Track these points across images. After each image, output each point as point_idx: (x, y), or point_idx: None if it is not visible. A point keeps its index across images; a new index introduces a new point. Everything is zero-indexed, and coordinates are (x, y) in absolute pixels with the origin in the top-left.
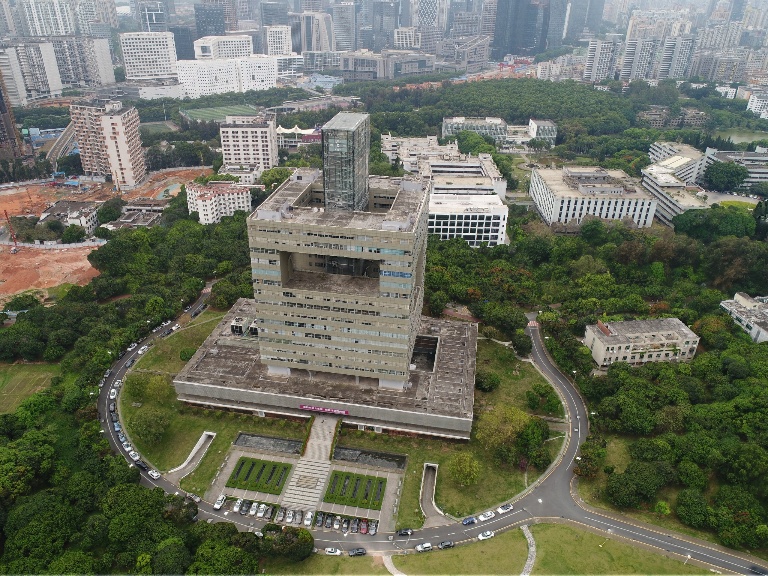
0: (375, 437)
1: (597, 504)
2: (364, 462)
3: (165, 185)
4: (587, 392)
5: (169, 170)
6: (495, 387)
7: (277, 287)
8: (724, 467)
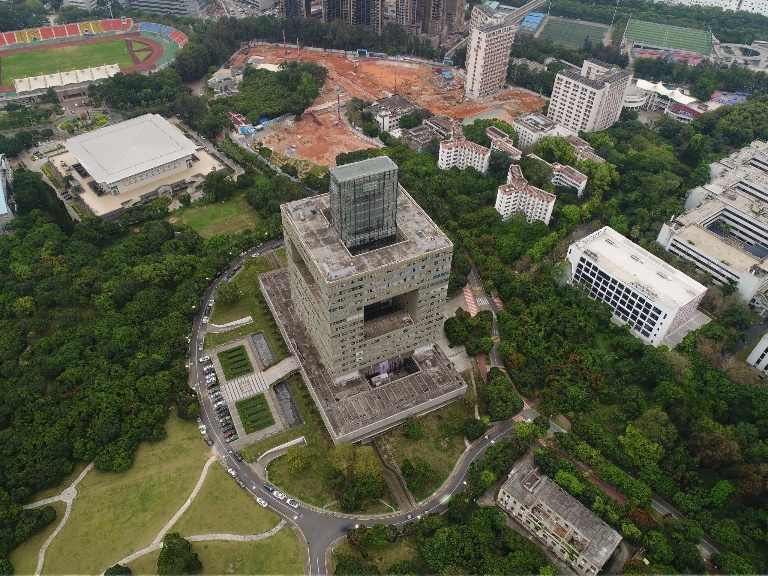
0: (306, 397)
1: (335, 561)
2: (282, 404)
3: (498, 106)
4: (450, 504)
5: (525, 91)
6: (410, 438)
7: (291, 259)
8: None
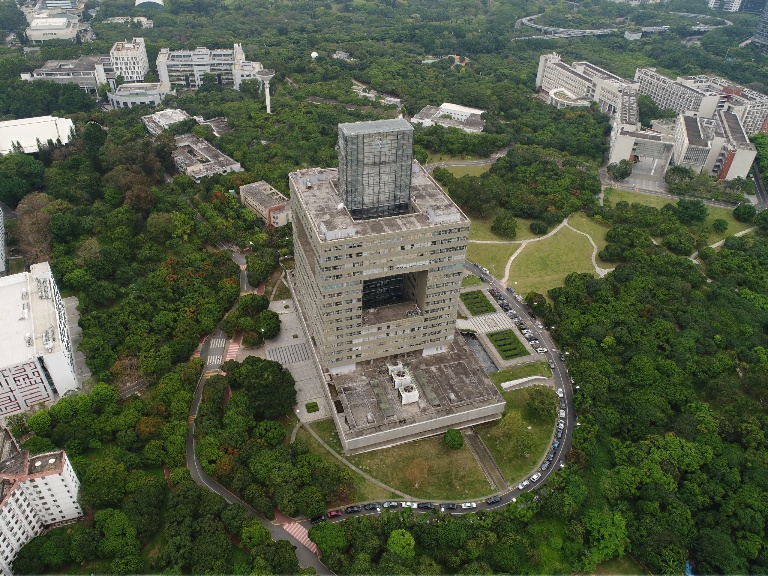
0: None
1: None
2: None
3: None
4: None
5: None
6: None
7: None
8: None
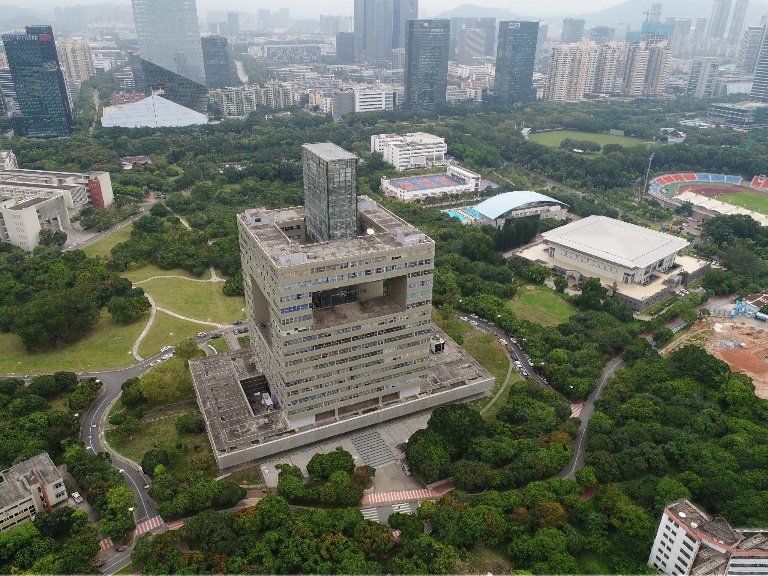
0: None
1: None
2: None
3: None
4: None
5: None
6: None
7: None
8: None
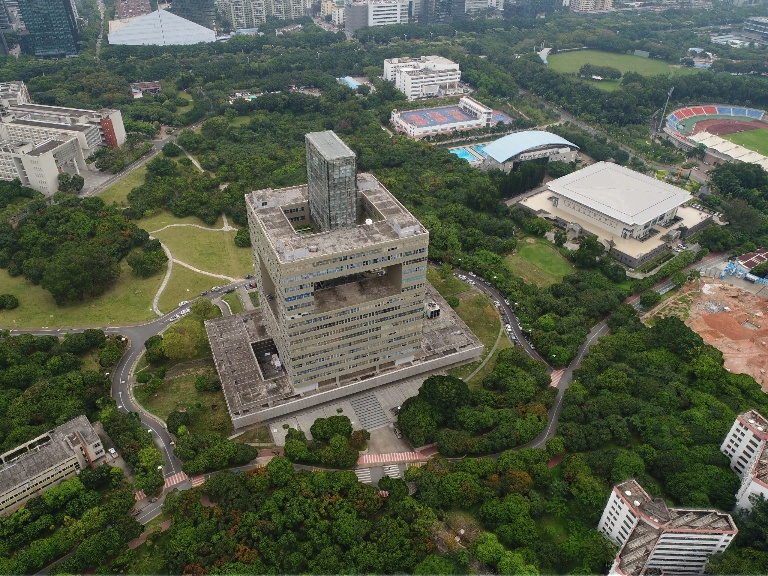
0: None
1: None
2: None
3: None
4: None
5: None
6: None
7: None
8: (8, 365)
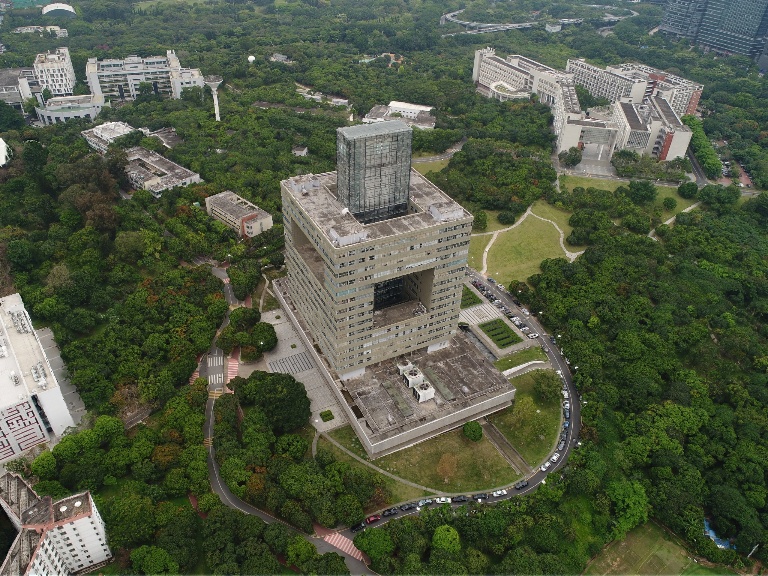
0: None
1: None
2: None
3: None
4: None
5: None
6: None
7: None
8: None
